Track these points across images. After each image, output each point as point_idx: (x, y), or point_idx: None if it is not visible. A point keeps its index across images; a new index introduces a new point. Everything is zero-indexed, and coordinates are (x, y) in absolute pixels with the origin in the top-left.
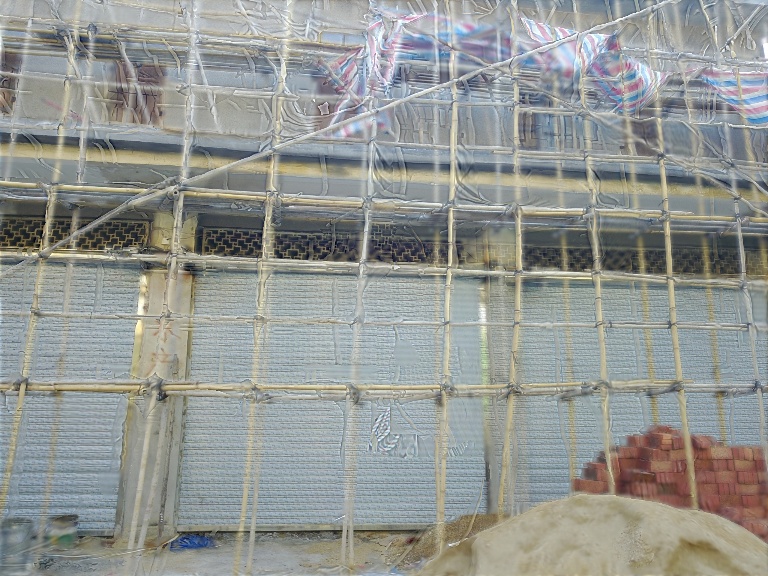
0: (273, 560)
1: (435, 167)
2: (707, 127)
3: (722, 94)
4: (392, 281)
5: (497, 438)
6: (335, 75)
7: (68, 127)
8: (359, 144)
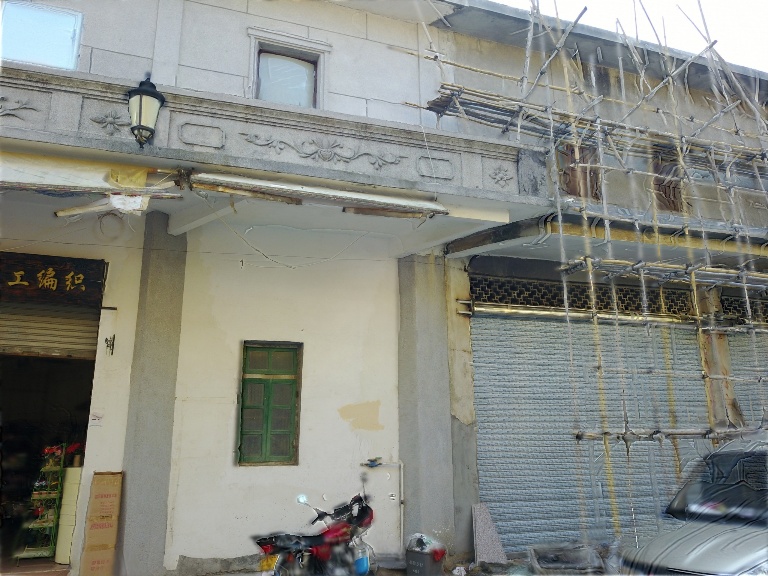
0: None
1: None
2: None
3: None
4: None
5: None
6: None
7: None
8: None
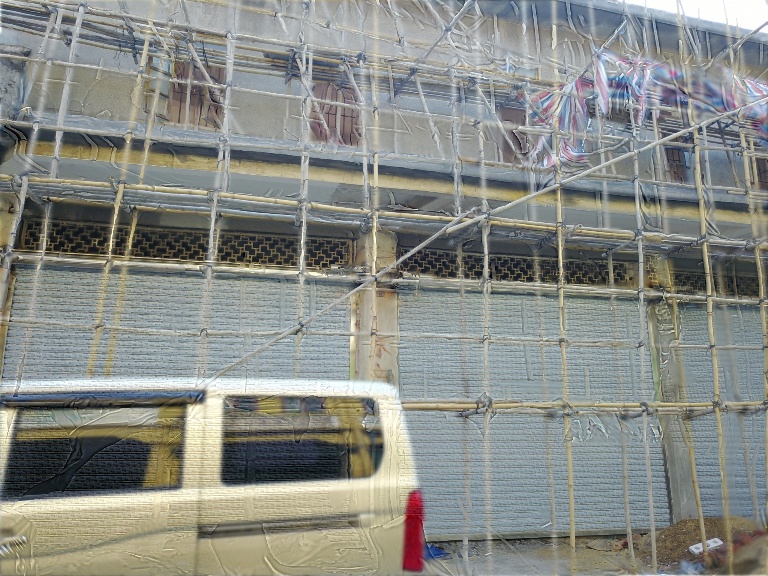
0: (548, 566)
1: (684, 204)
2: None
3: None
4: (572, 302)
5: (741, 449)
6: (536, 109)
7: (331, 150)
8: (626, 181)
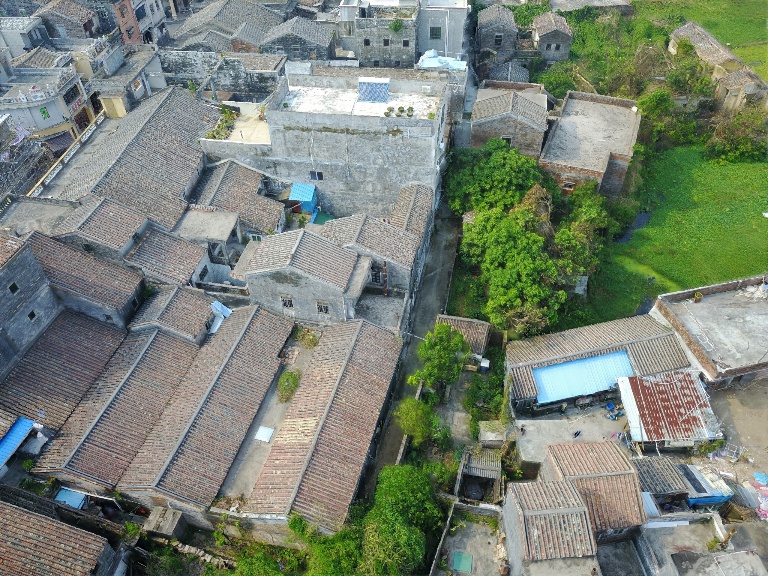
0: None
1: None
2: None
3: None
4: None
5: None
6: None
7: None
8: (5, 189)
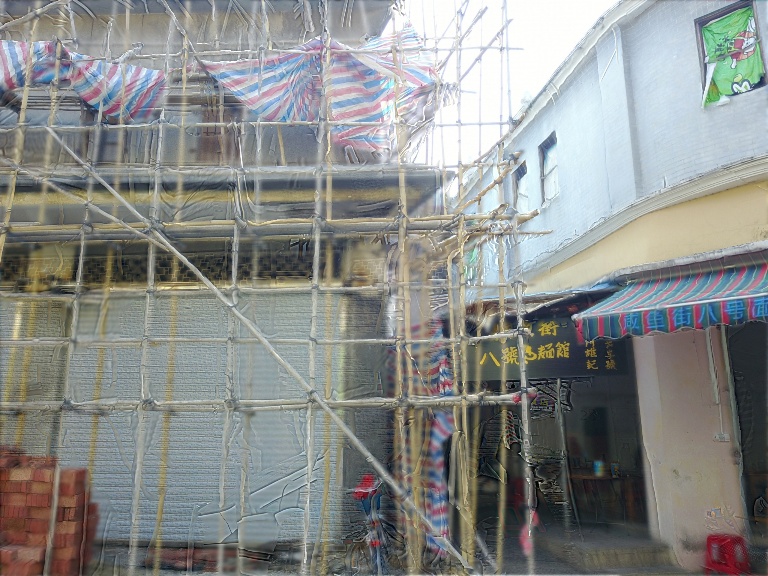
0: None
1: None
2: (77, 131)
3: (227, 86)
4: None
5: None
6: None
7: None
8: None
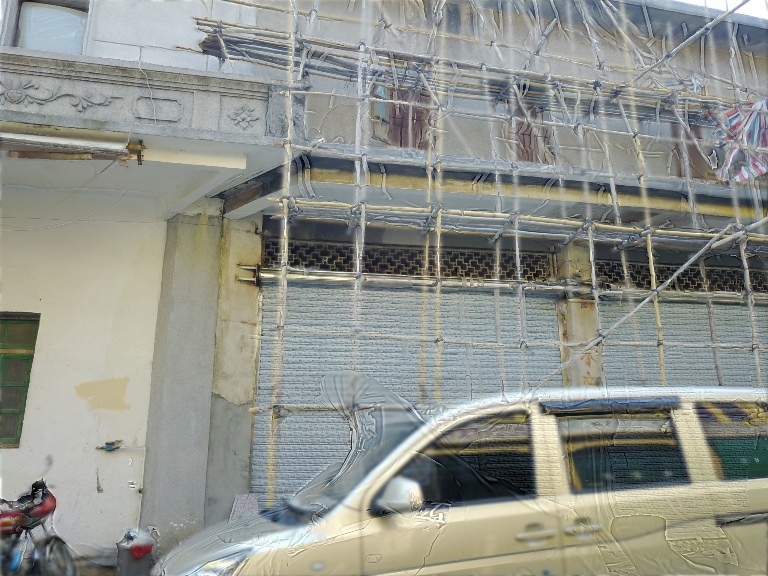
0: None
1: None
2: None
3: None
4: (754, 310)
5: None
6: (725, 126)
7: (567, 171)
8: None
